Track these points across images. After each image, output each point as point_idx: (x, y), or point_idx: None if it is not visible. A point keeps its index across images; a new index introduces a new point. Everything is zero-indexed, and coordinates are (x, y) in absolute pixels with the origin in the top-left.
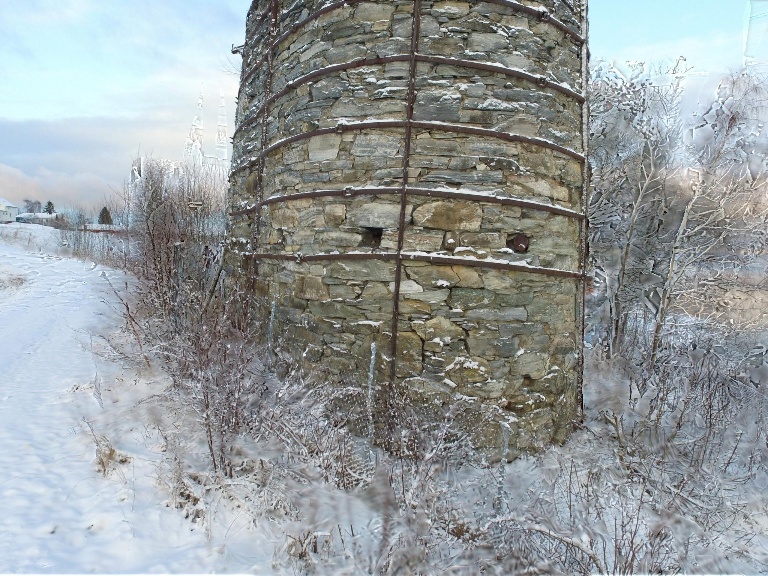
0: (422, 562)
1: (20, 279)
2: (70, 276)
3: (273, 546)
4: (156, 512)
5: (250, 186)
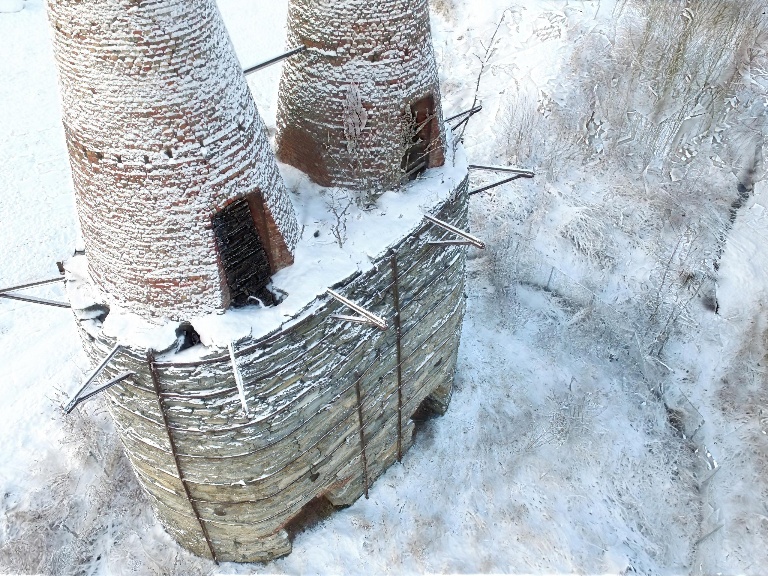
0: (25, 522)
1: (454, 84)
2: (492, 90)
3: (64, 470)
4: (61, 429)
5: (235, 277)
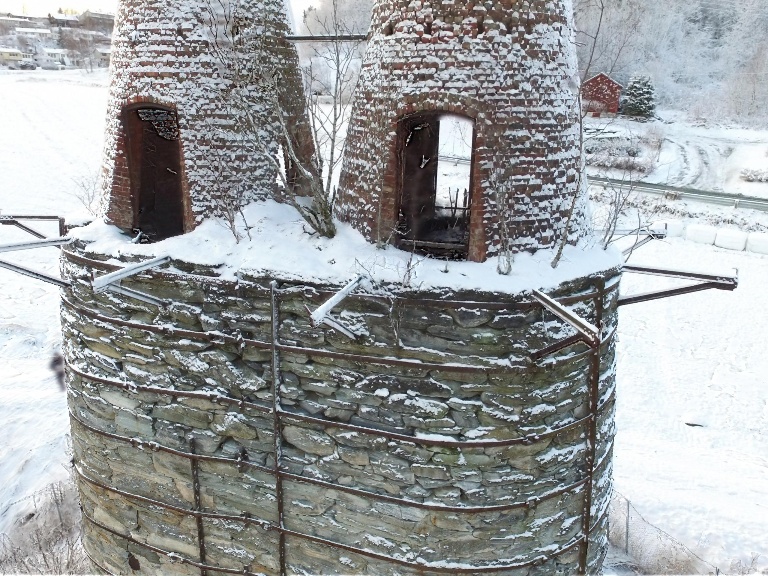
0: None
1: None
2: None
3: None
4: None
5: None
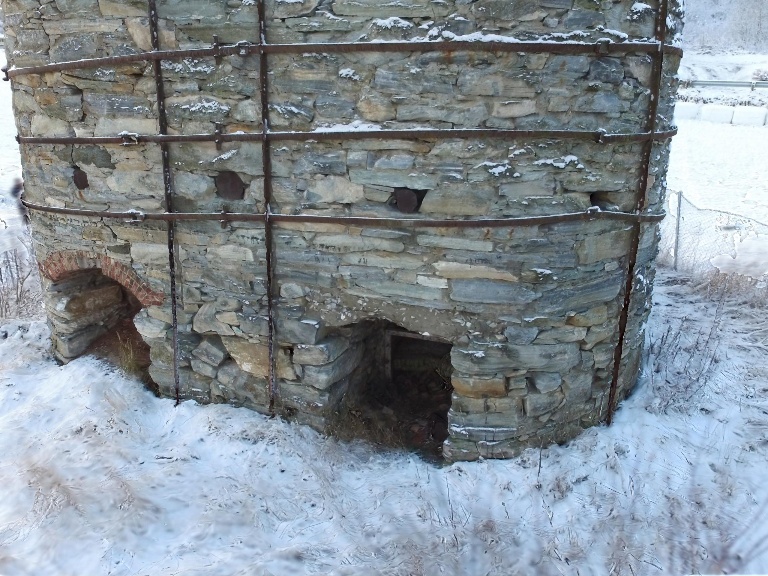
0: None
1: None
2: None
3: None
4: None
5: None
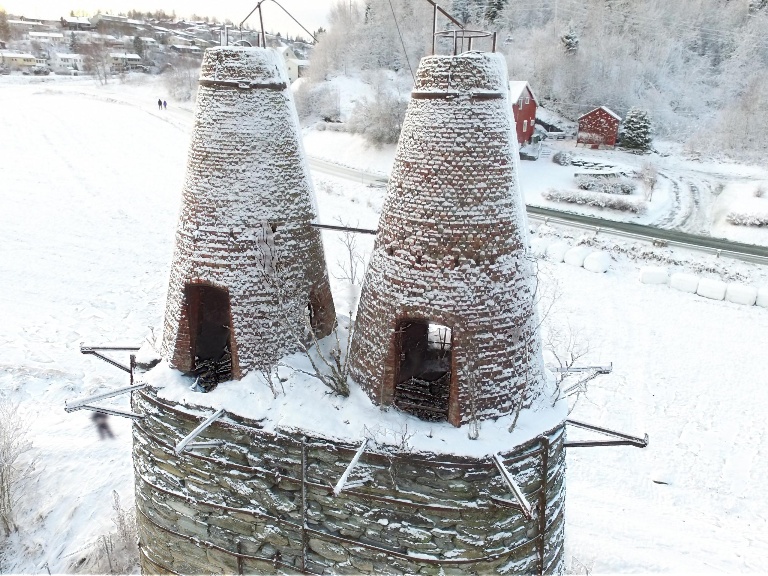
0: None
1: None
2: None
3: None
4: None
5: None
